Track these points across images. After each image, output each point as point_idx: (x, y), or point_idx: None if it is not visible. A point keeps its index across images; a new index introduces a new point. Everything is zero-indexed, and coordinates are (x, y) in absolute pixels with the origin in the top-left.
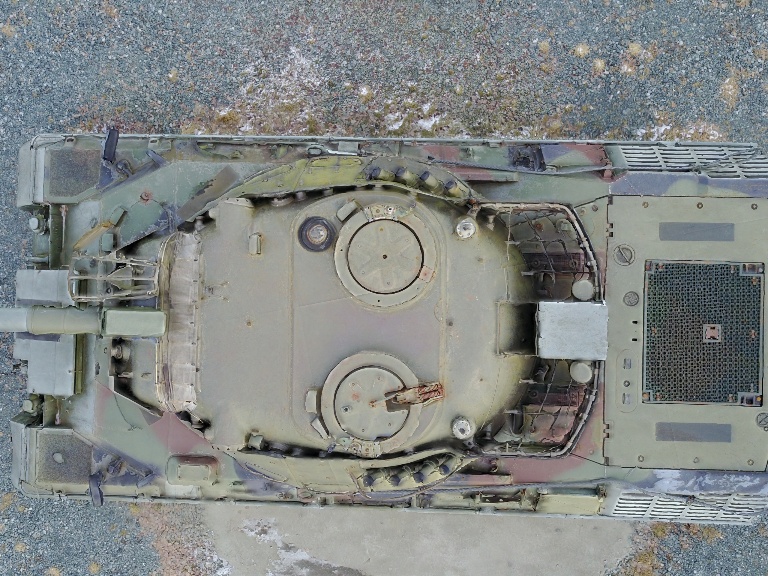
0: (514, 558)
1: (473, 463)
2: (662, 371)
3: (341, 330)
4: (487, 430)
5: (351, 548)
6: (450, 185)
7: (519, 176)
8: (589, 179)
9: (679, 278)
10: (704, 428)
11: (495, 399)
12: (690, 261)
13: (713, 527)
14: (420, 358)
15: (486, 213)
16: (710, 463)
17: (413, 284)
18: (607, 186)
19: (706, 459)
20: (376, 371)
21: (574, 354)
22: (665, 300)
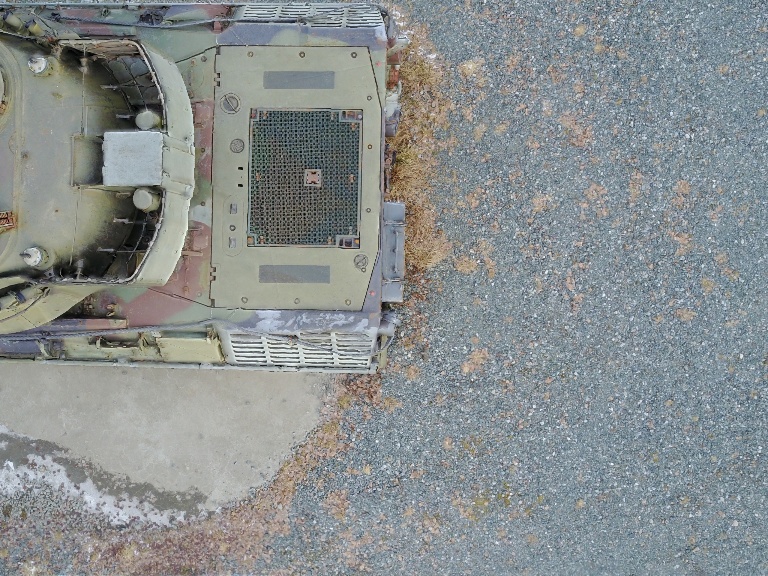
0: (206, 430)
1: (95, 310)
2: (266, 215)
3: None
4: (78, 266)
5: (48, 421)
6: (27, 23)
7: (137, 30)
8: (200, 31)
9: (282, 125)
10: (305, 270)
11: (77, 232)
12: (292, 108)
13: (394, 398)
14: None
15: (78, 56)
16: (309, 303)
17: None
18: (214, 37)
19: (306, 299)
20: None
21: (132, 180)
22: (269, 146)
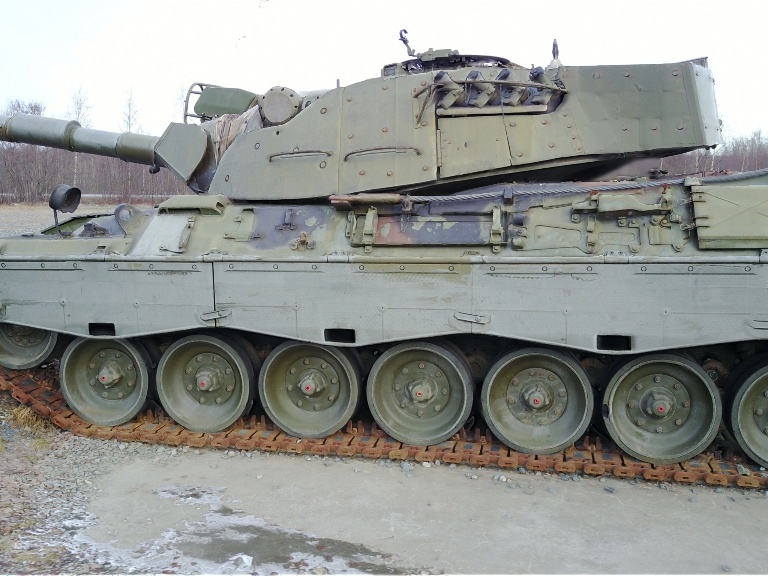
0: (732, 563)
1: None
2: None
3: None
4: None
5: (358, 522)
6: None
7: None
8: None
9: None
10: None
11: None
12: None
13: None
14: None
15: None
16: None
17: None
18: None
19: None
20: None
21: None
22: None
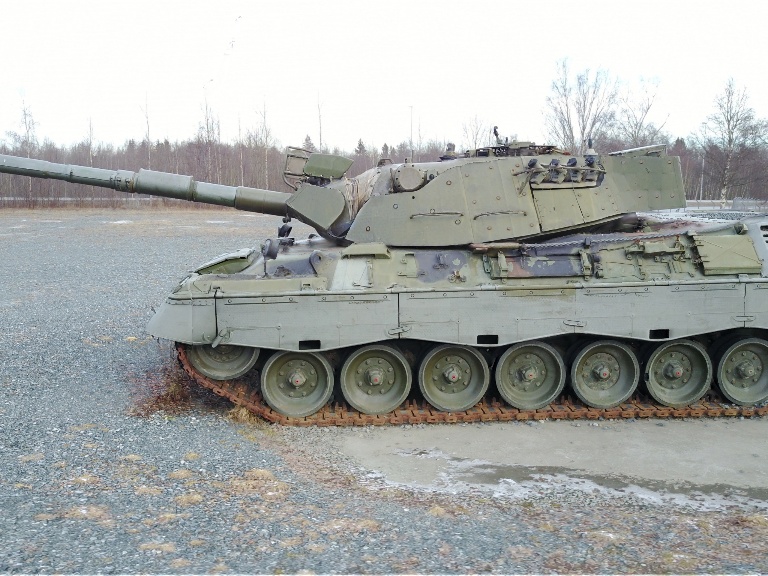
0: None
1: None
2: None
3: None
4: None
5: (544, 456)
6: None
7: None
8: None
9: None
10: None
11: None
12: None
13: None
14: None
15: None
16: None
17: None
18: None
19: None
20: None
21: None
22: None
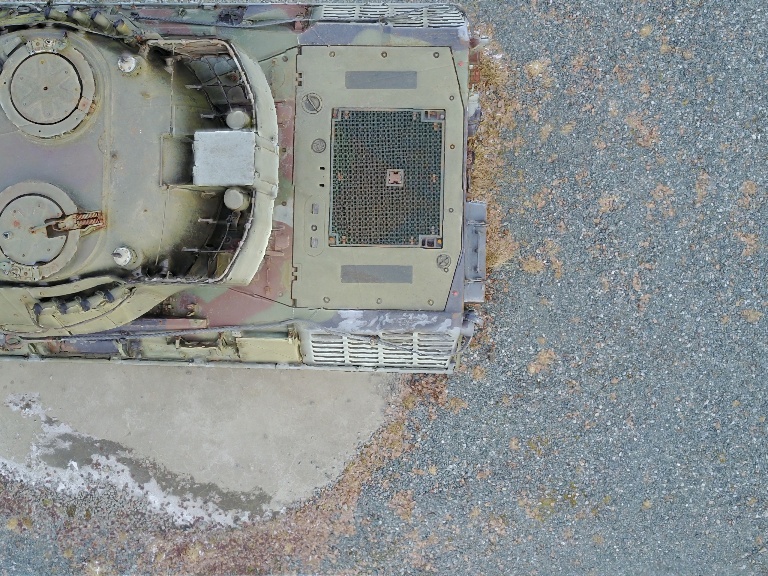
0: (270, 431)
1: (174, 310)
2: (348, 215)
3: (10, 163)
4: (164, 266)
5: (112, 422)
6: (116, 23)
7: (217, 30)
8: (281, 31)
9: (364, 125)
10: (387, 270)
11: (165, 232)
12: (375, 108)
13: (460, 398)
14: (84, 189)
15: (164, 56)
16: (392, 303)
17: (72, 115)
18: (296, 37)
19: (388, 299)
20: (36, 199)
21: (224, 180)
22: (351, 146)
